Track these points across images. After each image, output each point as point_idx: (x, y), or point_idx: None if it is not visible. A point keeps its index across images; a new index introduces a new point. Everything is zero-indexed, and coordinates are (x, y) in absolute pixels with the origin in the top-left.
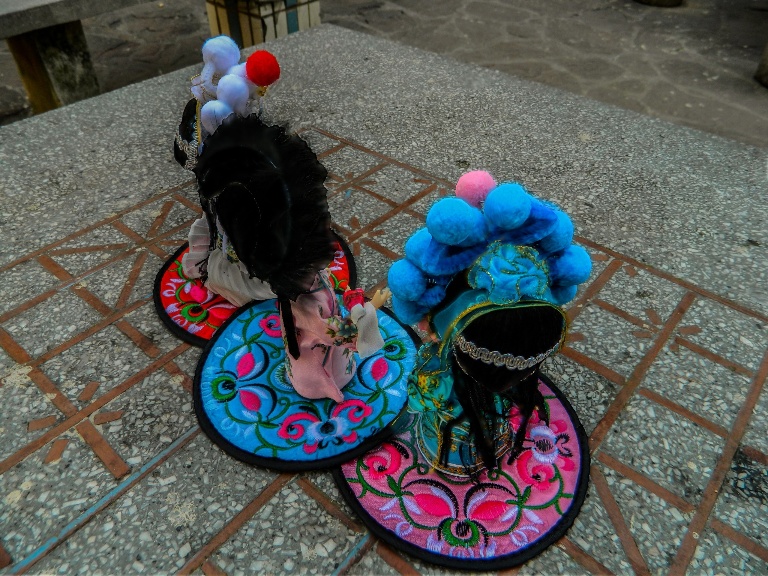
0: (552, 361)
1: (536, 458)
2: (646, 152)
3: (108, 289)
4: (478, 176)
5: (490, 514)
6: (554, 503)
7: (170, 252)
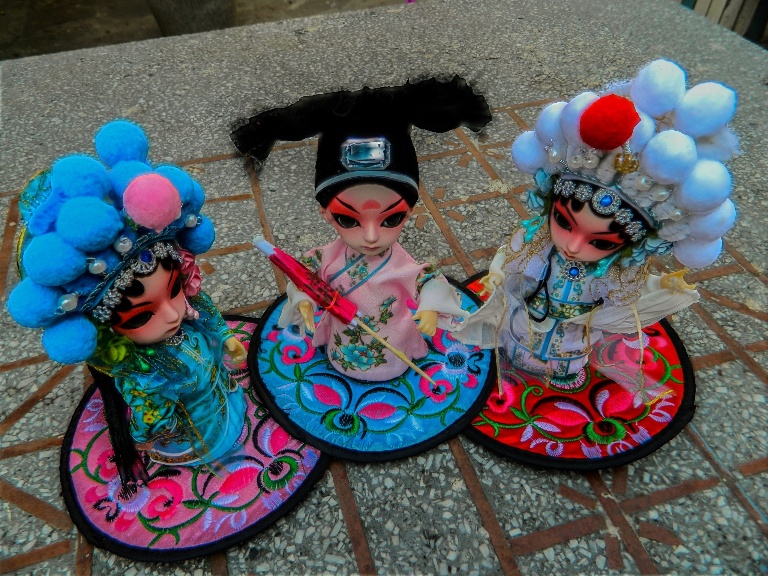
0: None
1: None
2: None
3: None
4: (141, 178)
5: None
6: (84, 452)
7: None
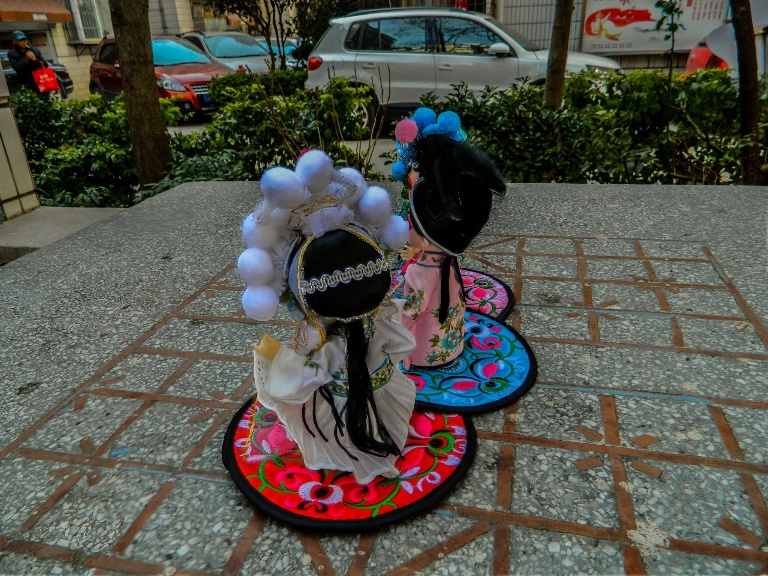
0: None
1: None
2: (5, 302)
3: (470, 568)
4: None
5: None
6: None
7: (349, 556)
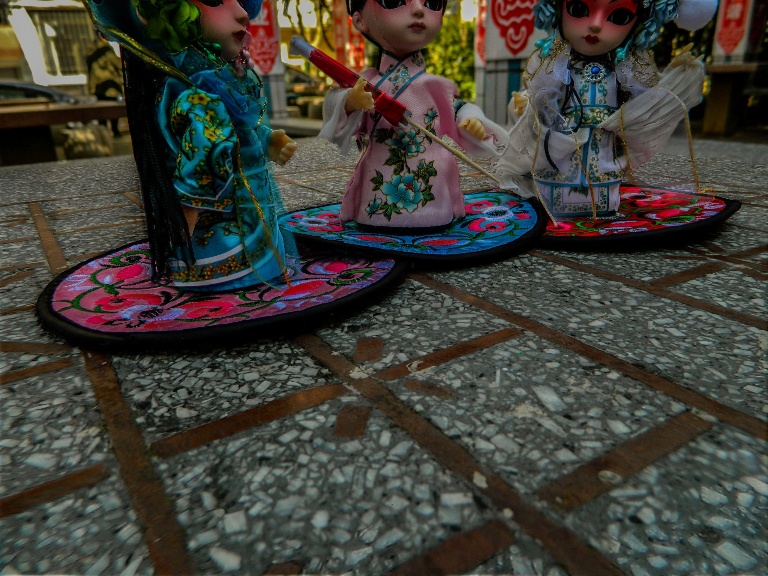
0: (304, 373)
1: (142, 304)
2: None
3: None
4: None
5: (125, 271)
6: (74, 300)
7: None
